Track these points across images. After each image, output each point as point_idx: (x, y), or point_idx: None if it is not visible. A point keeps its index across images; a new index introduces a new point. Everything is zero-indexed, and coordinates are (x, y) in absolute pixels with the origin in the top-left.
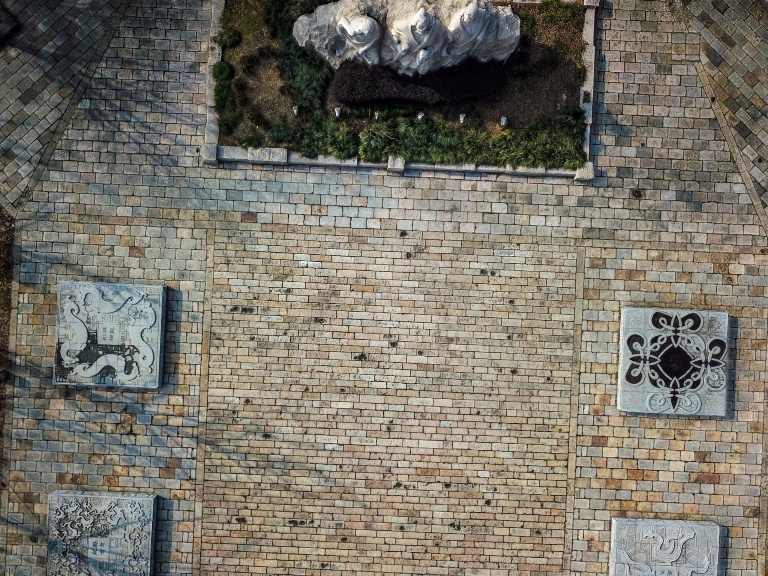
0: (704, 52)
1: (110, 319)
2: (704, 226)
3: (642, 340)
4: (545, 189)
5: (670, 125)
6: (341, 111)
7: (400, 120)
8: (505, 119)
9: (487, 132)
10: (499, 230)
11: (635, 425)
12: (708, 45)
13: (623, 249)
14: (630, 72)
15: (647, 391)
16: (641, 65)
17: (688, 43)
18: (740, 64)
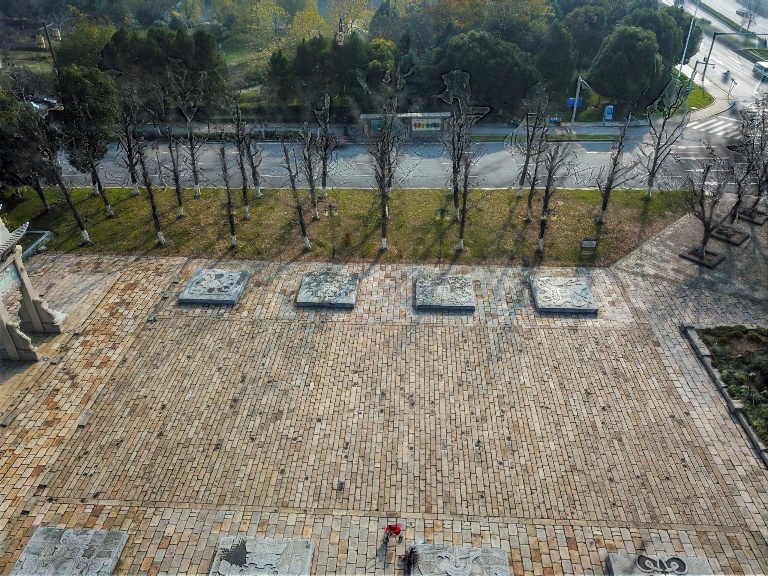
0: None
1: (572, 292)
2: None
3: (682, 570)
4: None
5: None
6: (754, 377)
7: None
8: None
9: None
10: (722, 470)
11: (596, 575)
12: None
13: (759, 565)
14: None
15: (635, 575)
16: None
17: None
18: None
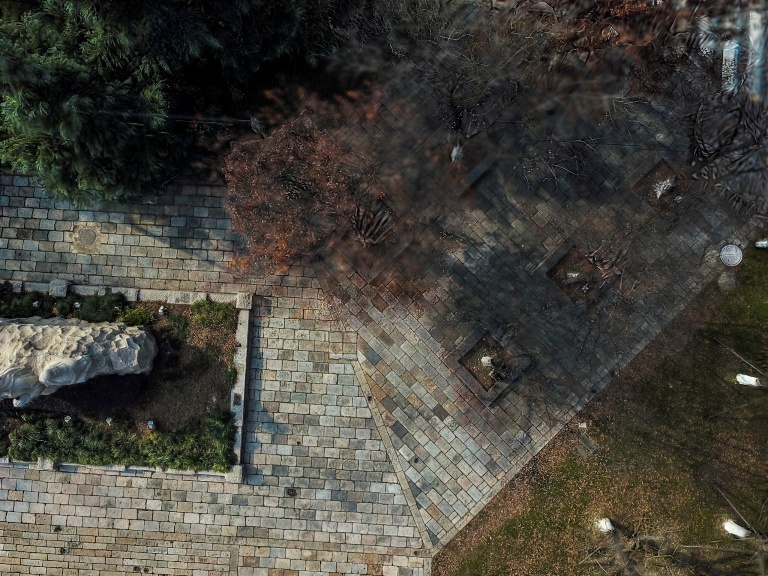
0: (361, 351)
1: None
2: (358, 526)
3: None
4: (200, 486)
5: (326, 424)
6: None
7: (47, 423)
8: (151, 424)
9: (137, 433)
10: (153, 527)
11: None
12: (366, 344)
13: (277, 548)
14: (287, 370)
15: None
16: (298, 363)
17: (345, 342)
18: (398, 363)
